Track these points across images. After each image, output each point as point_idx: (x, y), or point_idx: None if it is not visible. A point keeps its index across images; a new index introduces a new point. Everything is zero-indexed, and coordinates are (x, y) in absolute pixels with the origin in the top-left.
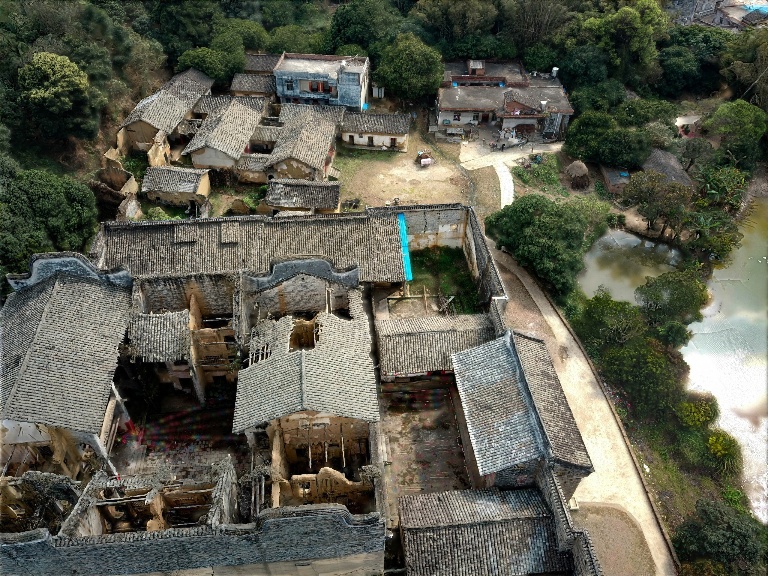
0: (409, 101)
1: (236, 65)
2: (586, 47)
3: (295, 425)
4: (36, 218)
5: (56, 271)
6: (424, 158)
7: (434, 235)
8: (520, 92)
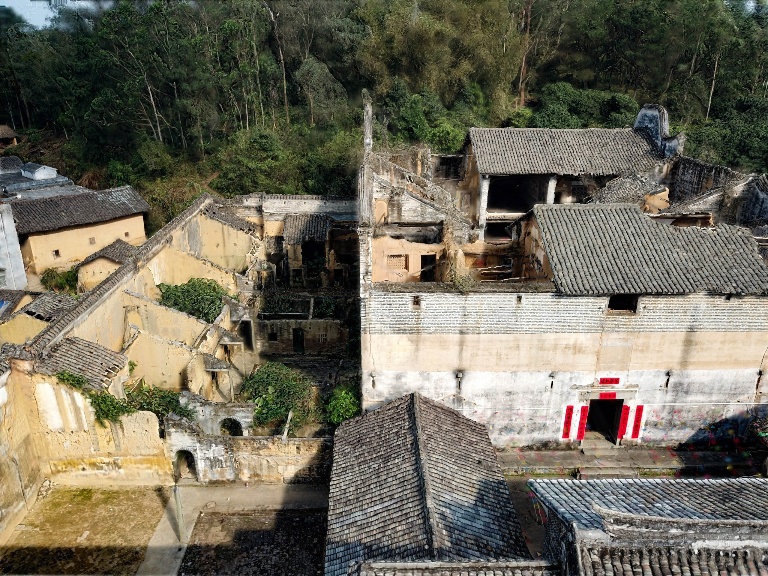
0: None
1: None
2: None
3: None
4: None
5: None
6: None
7: None
8: None
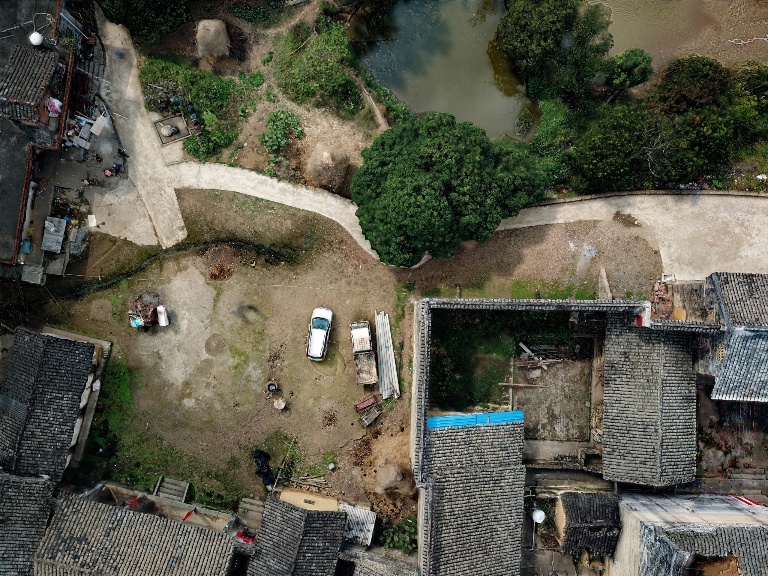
0: None
1: None
2: None
3: None
4: None
5: None
6: None
7: None
8: None
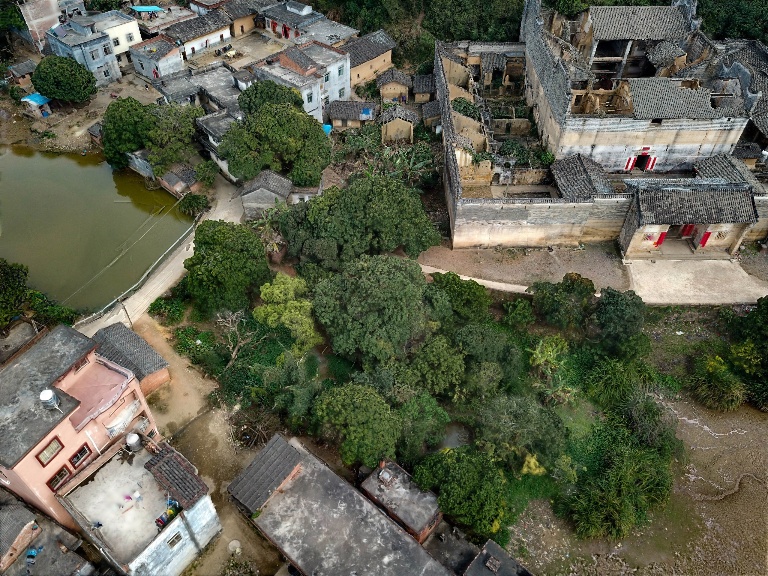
0: None
1: None
2: None
3: None
4: (734, 7)
5: None
6: None
7: None
8: None
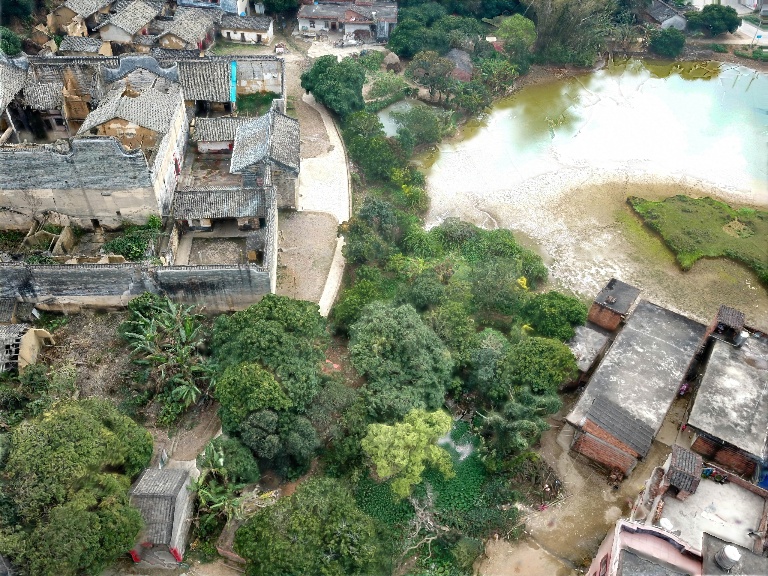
0: (281, 15)
1: None
2: None
3: (115, 133)
4: None
5: None
6: (279, 47)
7: (261, 82)
8: None
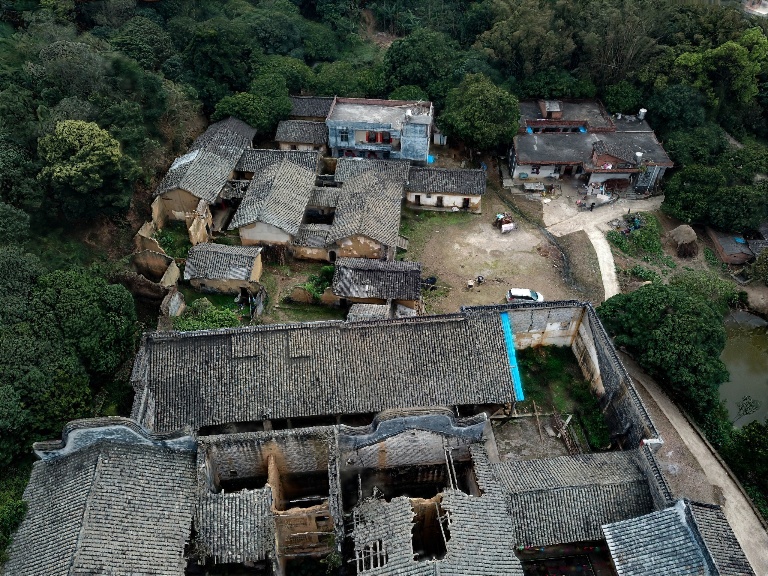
0: (477, 149)
1: (281, 112)
2: (681, 86)
3: None
4: (65, 341)
5: (98, 439)
6: (505, 223)
7: (539, 334)
8: (606, 139)
